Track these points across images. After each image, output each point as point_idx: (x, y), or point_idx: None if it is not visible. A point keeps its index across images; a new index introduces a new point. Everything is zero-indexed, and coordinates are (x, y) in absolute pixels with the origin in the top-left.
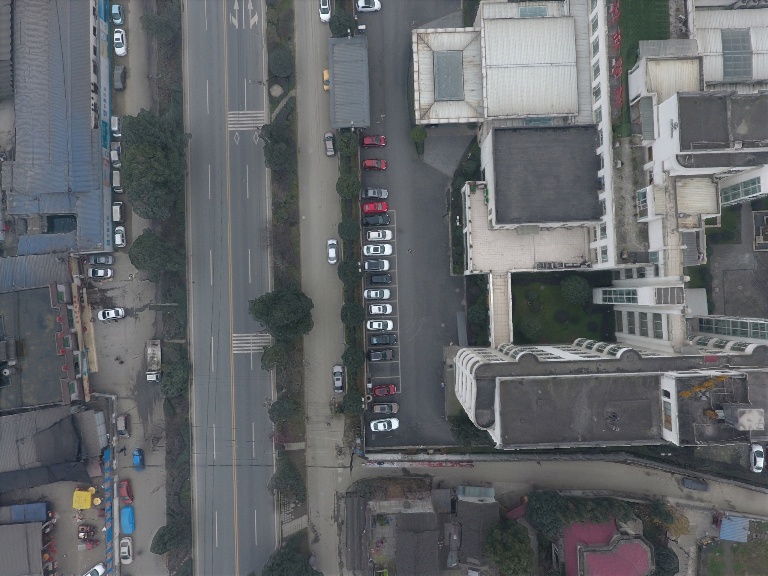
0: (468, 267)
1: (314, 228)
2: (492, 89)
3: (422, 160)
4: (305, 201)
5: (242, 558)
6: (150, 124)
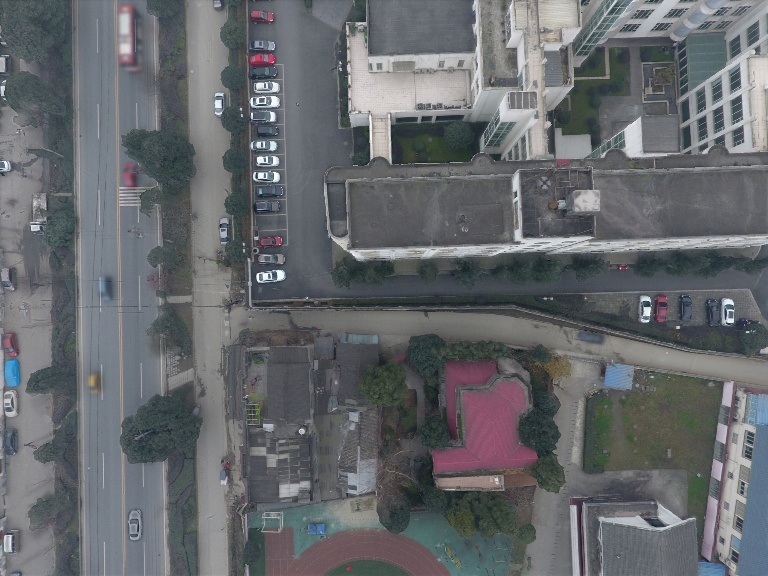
0: None
1: (202, 82)
2: None
3: (310, 13)
4: (193, 55)
5: (127, 411)
6: None
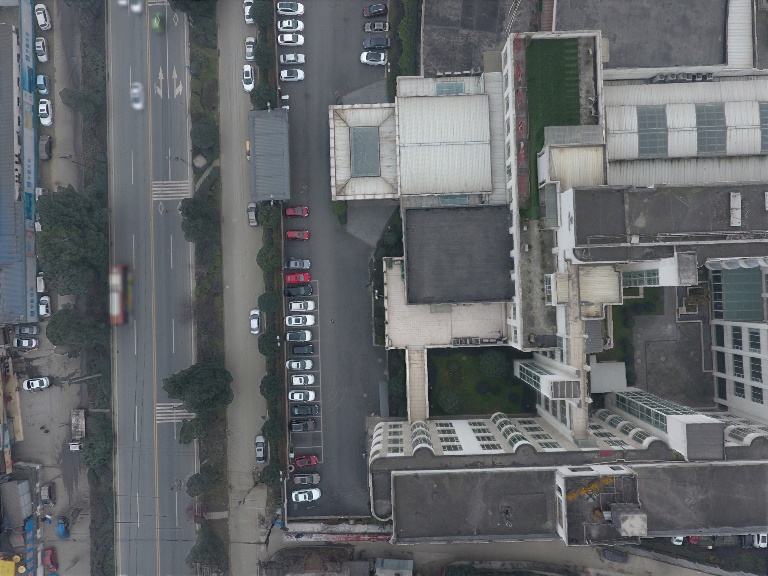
0: None
1: (238, 298)
2: (406, 167)
3: (345, 230)
4: (229, 271)
5: None
6: (64, 204)
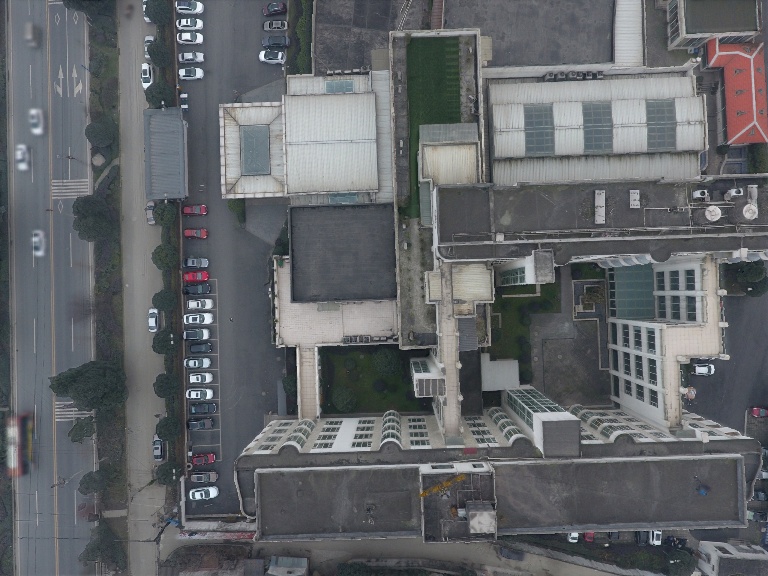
0: None
1: (137, 296)
2: (292, 166)
3: (244, 228)
4: (128, 269)
5: None
6: None
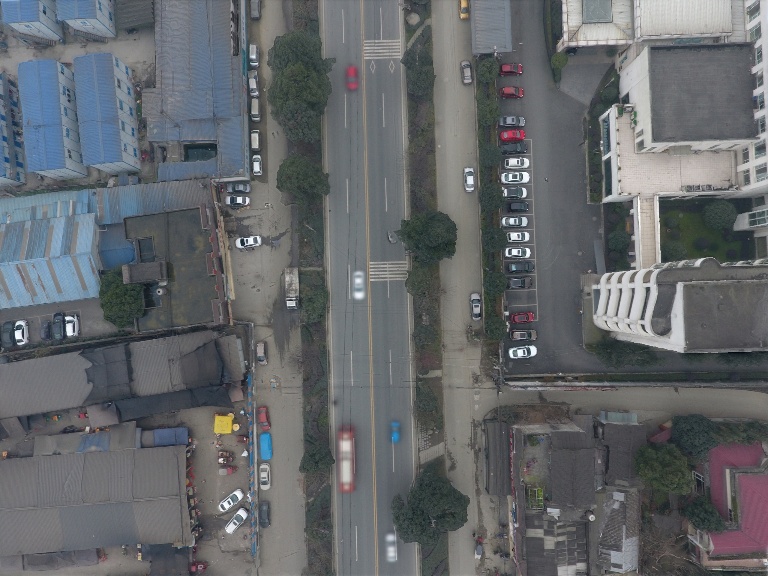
0: (612, 191)
1: (450, 157)
2: (645, 9)
3: (558, 88)
4: (441, 130)
5: (380, 484)
6: (305, 43)
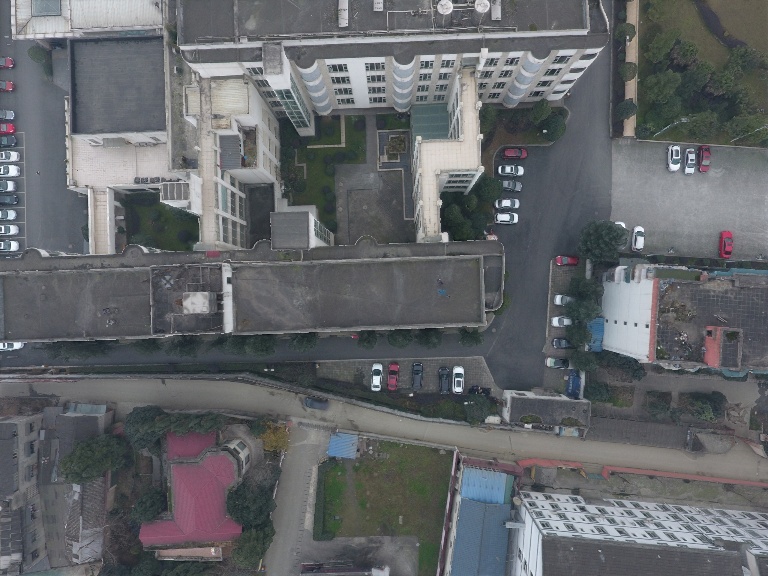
0: None
1: None
2: (76, 1)
3: (51, 82)
4: None
5: None
6: None
